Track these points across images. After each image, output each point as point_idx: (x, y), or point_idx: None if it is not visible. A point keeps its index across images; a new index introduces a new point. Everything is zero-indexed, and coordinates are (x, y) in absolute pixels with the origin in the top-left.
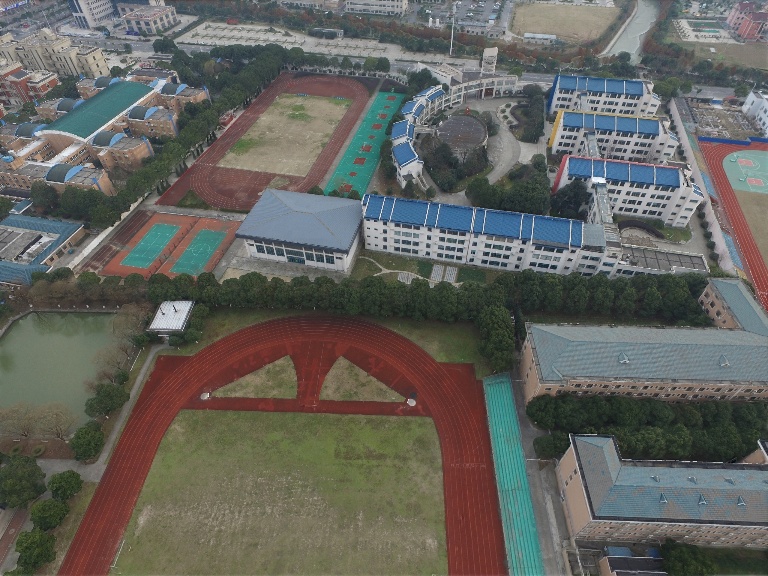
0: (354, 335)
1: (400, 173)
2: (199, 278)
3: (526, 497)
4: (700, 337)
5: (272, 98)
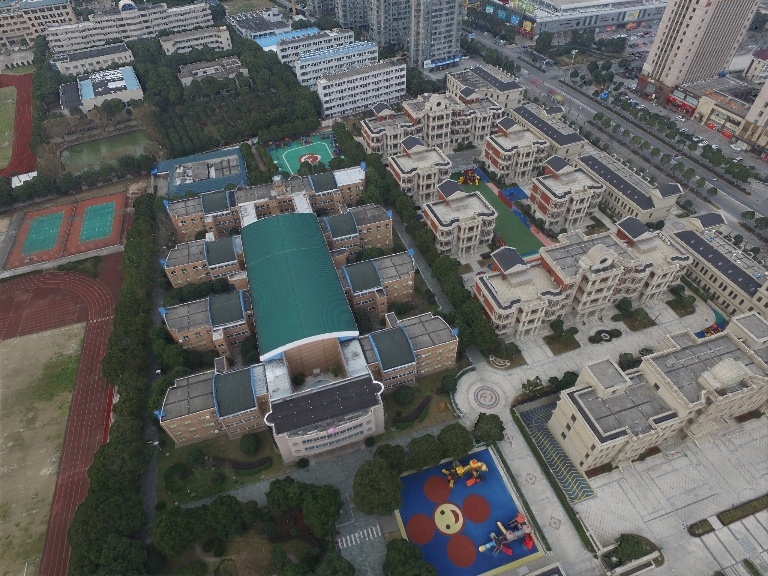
0: None
1: None
2: None
3: None
4: None
5: (49, 575)
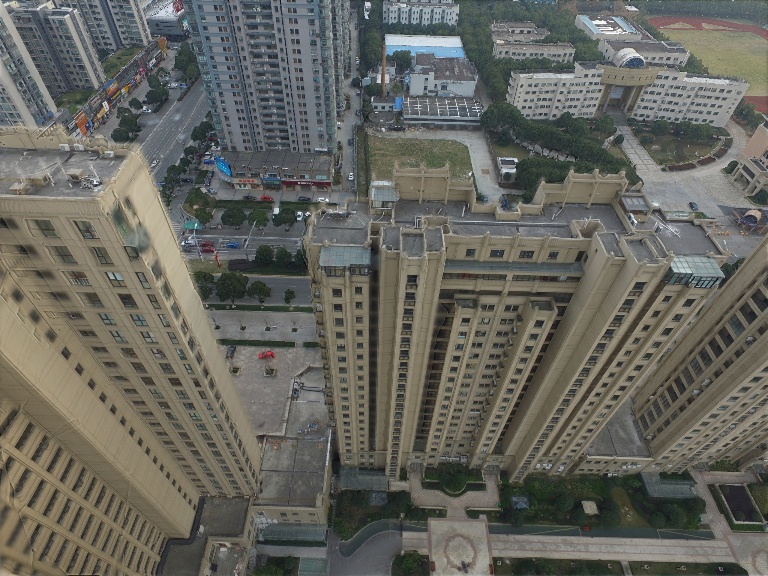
0: (702, 19)
1: None
2: None
3: None
4: None
5: None
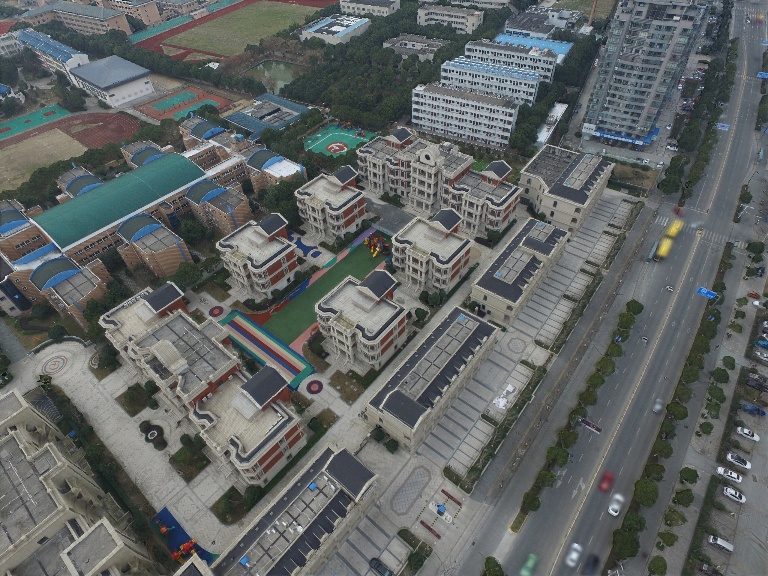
0: None
1: (13, 96)
2: (187, 63)
3: (162, 25)
4: (69, 6)
5: None
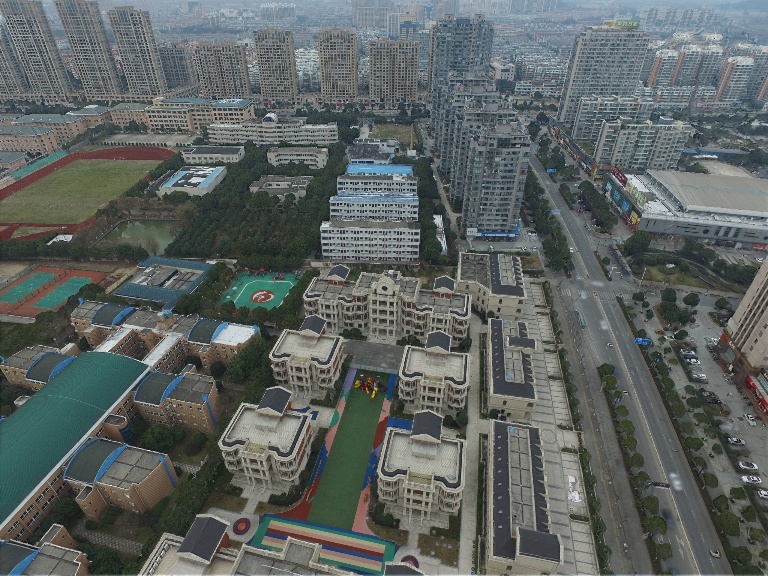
0: None
1: None
2: (30, 242)
3: None
4: None
5: None
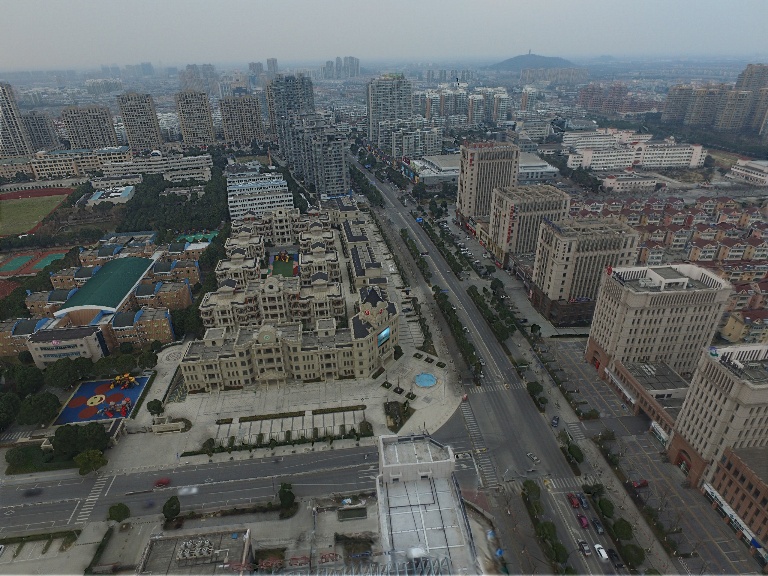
0: None
1: None
2: None
3: None
4: None
5: None
